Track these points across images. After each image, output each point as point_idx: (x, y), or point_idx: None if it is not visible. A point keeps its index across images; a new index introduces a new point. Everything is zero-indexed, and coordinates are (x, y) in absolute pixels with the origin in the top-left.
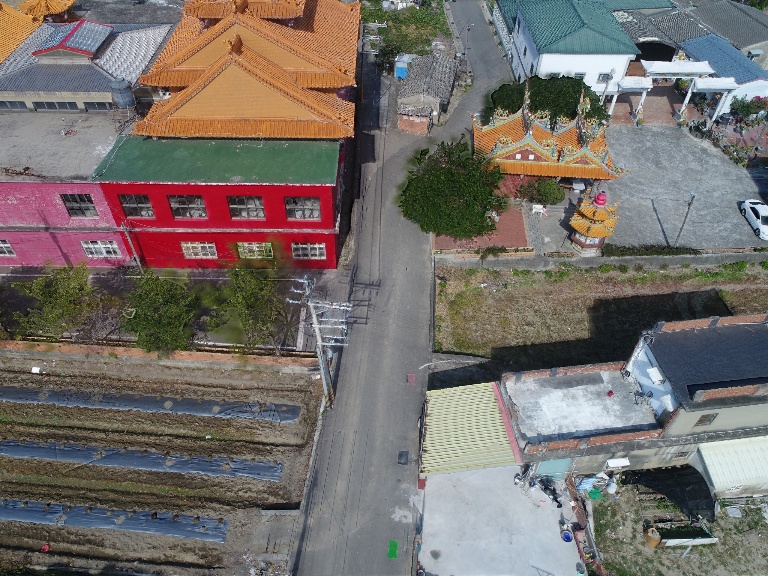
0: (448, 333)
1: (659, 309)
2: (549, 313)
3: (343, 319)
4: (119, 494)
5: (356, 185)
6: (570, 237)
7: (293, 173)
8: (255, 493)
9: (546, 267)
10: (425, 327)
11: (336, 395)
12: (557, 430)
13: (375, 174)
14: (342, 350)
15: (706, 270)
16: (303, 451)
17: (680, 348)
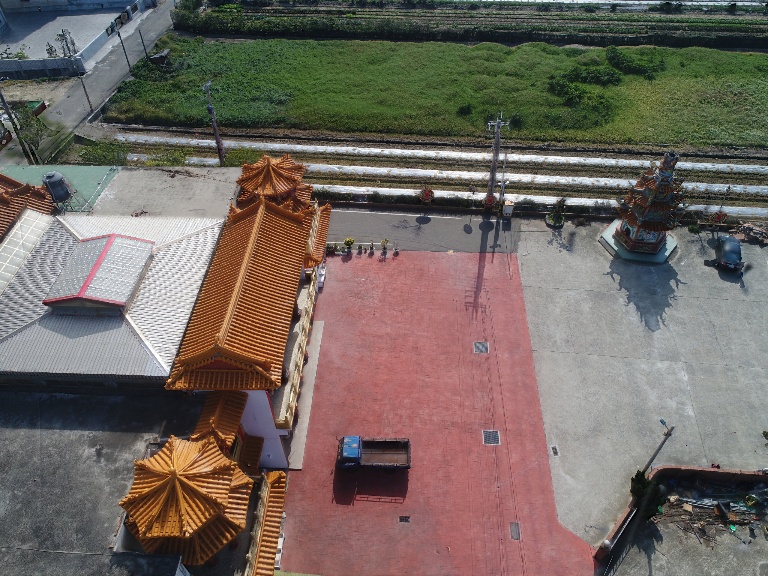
0: None
1: None
2: None
3: None
4: None
5: None
6: None
7: None
8: None
9: None
10: None
11: None
12: None
13: None
14: None
15: None
16: (65, 160)
17: None
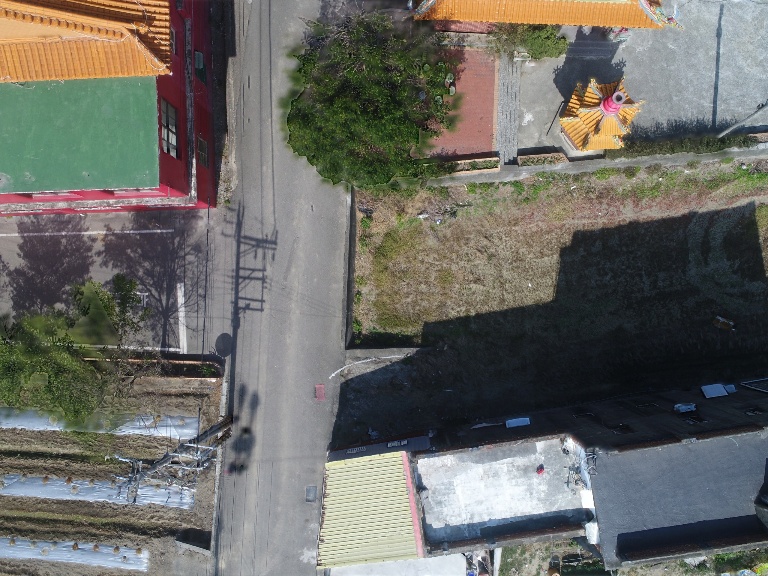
0: (370, 304)
1: (661, 246)
2: (508, 259)
3: (198, 457)
4: (35, 524)
5: (228, 21)
6: None
7: (87, 161)
8: (167, 521)
9: (517, 177)
10: (337, 314)
11: (234, 418)
12: (468, 520)
13: None
14: (235, 352)
15: (755, 165)
16: (208, 474)
17: (628, 477)
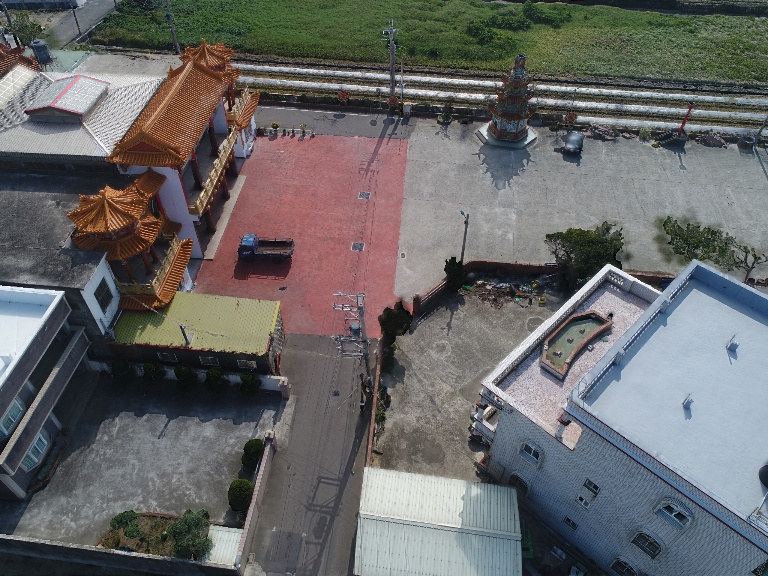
0: None
1: None
2: None
3: None
4: None
5: None
6: None
7: None
8: None
9: None
10: None
11: None
12: None
13: None
14: None
15: None
16: None
17: None
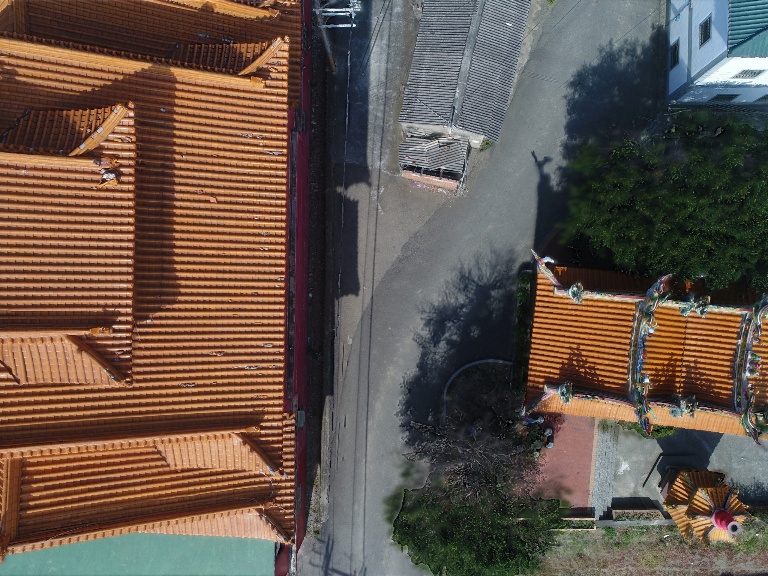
0: None
1: None
2: None
3: None
4: None
5: (327, 360)
6: (662, 467)
7: None
8: None
9: None
10: None
11: None
12: None
13: (358, 329)
14: None
15: None
16: None
17: None
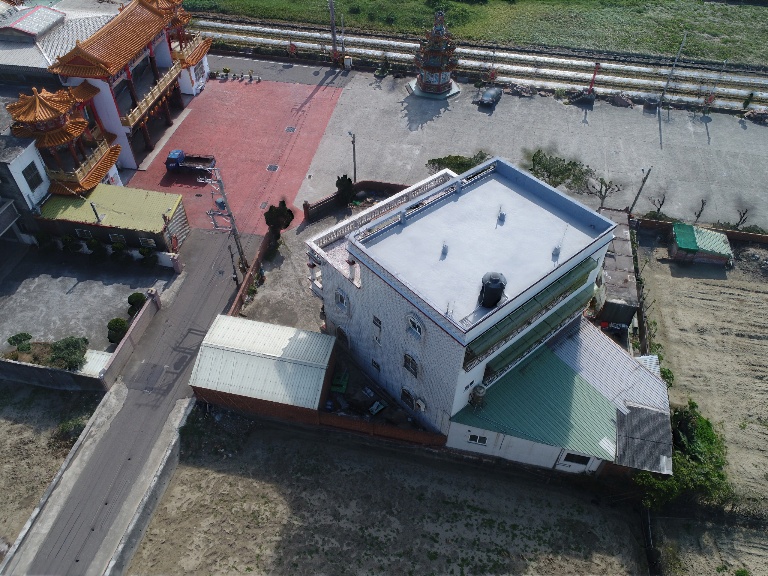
0: None
1: None
2: None
3: None
4: None
5: None
6: None
7: None
8: None
9: None
10: None
11: None
12: None
13: None
14: None
15: None
16: None
17: None
